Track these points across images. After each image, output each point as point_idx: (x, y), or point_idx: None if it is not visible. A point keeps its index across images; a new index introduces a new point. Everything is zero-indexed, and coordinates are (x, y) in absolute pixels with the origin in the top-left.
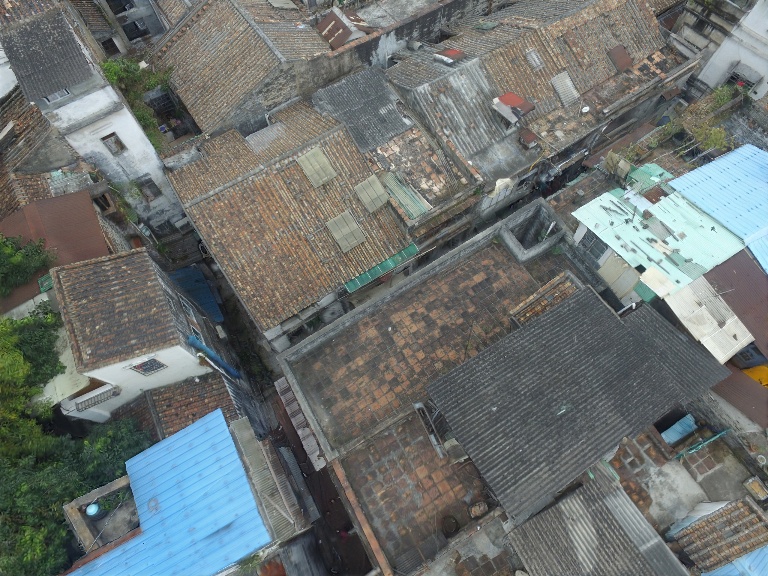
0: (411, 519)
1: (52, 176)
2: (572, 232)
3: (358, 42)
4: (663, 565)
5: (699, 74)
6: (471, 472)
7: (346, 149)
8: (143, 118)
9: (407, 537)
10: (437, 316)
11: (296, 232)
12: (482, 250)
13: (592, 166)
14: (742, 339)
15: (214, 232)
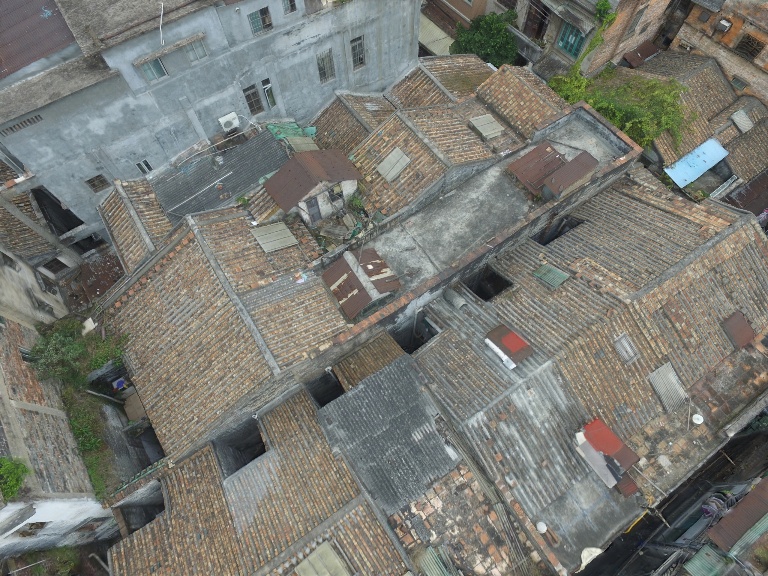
0: None
1: None
2: None
3: (380, 316)
4: None
5: None
6: None
7: (367, 532)
8: (82, 436)
9: None
10: None
11: None
12: None
13: (723, 545)
14: None
15: None
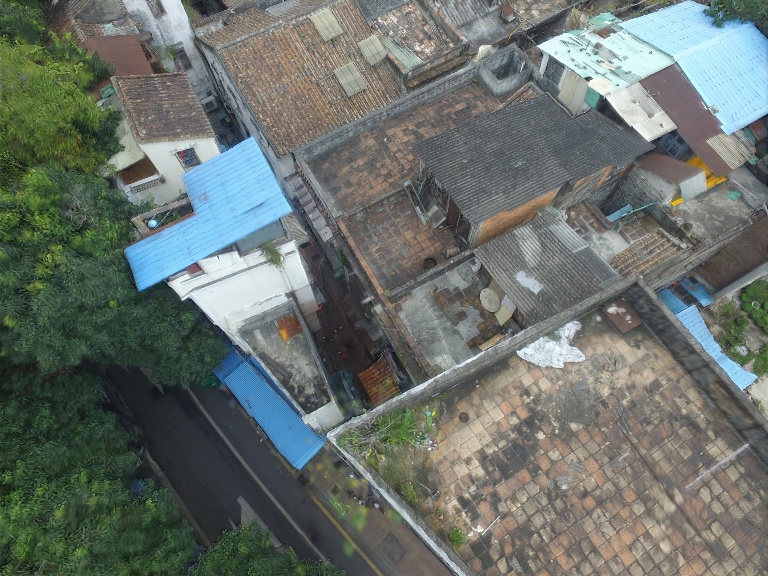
0: (399, 265)
1: (105, 27)
2: (538, 68)
3: None
4: (589, 259)
5: None
6: (448, 234)
7: (352, 13)
8: None
9: (396, 277)
10: (425, 132)
11: (308, 77)
12: (464, 87)
13: None
14: (667, 127)
15: (240, 72)
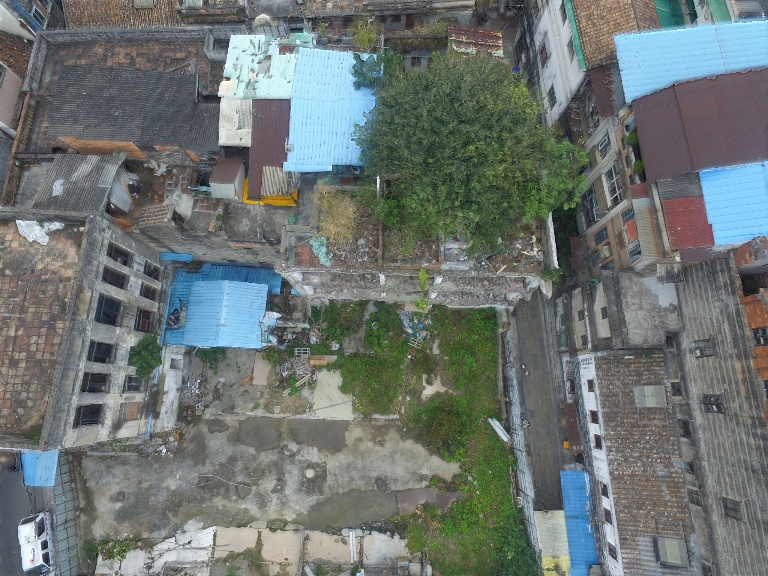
0: (49, 143)
1: None
2: None
3: None
4: (99, 194)
5: (535, 35)
6: None
7: None
8: None
9: (42, 149)
10: (139, 62)
11: None
12: (196, 42)
13: None
14: (243, 142)
15: None
